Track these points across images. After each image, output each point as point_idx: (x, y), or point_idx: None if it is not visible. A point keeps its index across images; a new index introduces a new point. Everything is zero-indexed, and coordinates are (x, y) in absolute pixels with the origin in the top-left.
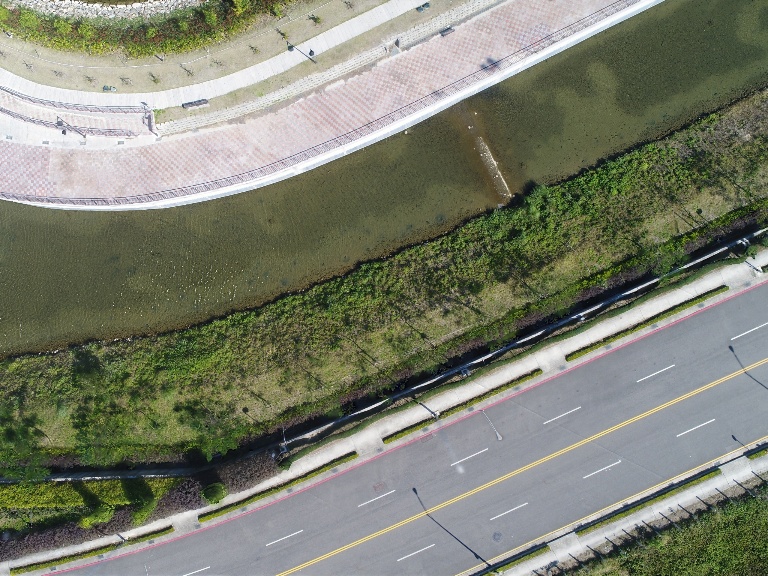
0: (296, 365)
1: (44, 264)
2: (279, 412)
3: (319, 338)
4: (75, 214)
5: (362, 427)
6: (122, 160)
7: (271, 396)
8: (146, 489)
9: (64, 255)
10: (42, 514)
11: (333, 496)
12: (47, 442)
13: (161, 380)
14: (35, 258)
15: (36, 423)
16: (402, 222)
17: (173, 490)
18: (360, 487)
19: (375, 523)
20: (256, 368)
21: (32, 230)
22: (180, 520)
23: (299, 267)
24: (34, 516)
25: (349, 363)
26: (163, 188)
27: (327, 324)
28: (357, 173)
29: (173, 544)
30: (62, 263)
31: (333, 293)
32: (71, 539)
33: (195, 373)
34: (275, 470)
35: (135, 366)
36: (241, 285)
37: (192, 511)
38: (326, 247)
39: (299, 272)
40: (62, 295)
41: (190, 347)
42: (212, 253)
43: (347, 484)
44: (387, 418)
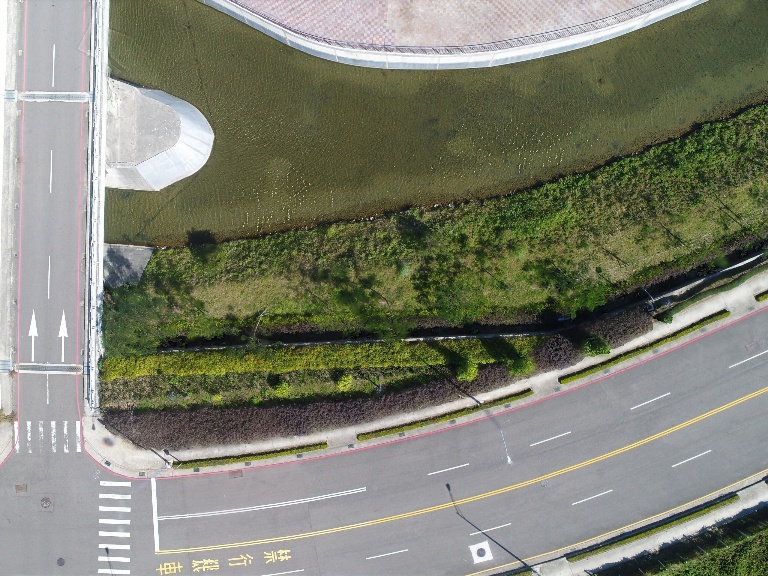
0: (655, 222)
1: (357, 127)
2: (634, 272)
3: (675, 195)
4: (391, 74)
5: (743, 280)
6: (466, 6)
7: (627, 255)
8: (510, 347)
9: (379, 117)
10: (392, 376)
11: (702, 357)
12: (384, 305)
13: (505, 240)
14: (347, 120)
15: (374, 284)
16: (741, 82)
17: (542, 347)
18: (731, 347)
19: (747, 385)
20: (609, 226)
21: (345, 91)
22: (539, 382)
23: (631, 129)
24: (386, 377)
25: (711, 220)
26: (510, 36)
27: (679, 182)
28: (693, 31)
29: (531, 408)
30: (377, 125)
31: (678, 152)
32: (431, 399)
33: (541, 233)
34: (649, 326)
35: (470, 228)
36: (568, 149)
37: (552, 373)
38: (660, 108)
39: (631, 135)
40: (376, 159)
41: (526, 209)
42: (538, 115)
43: (717, 344)
44: (760, 274)
